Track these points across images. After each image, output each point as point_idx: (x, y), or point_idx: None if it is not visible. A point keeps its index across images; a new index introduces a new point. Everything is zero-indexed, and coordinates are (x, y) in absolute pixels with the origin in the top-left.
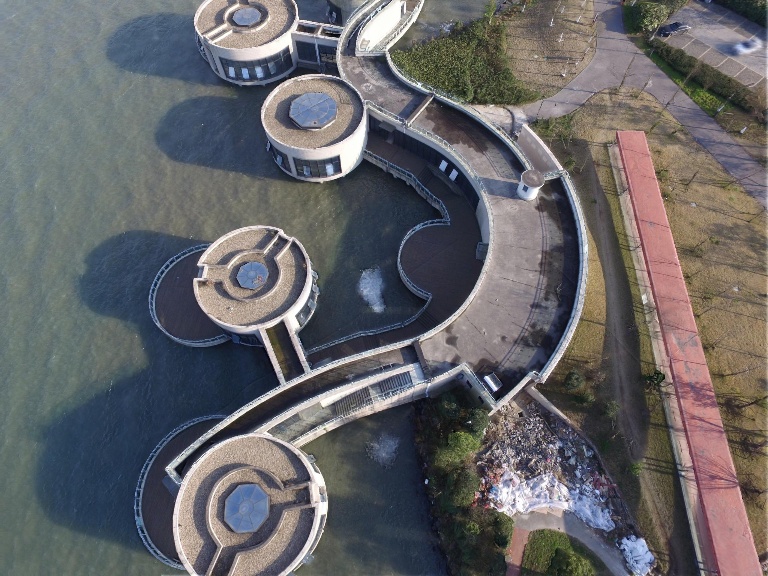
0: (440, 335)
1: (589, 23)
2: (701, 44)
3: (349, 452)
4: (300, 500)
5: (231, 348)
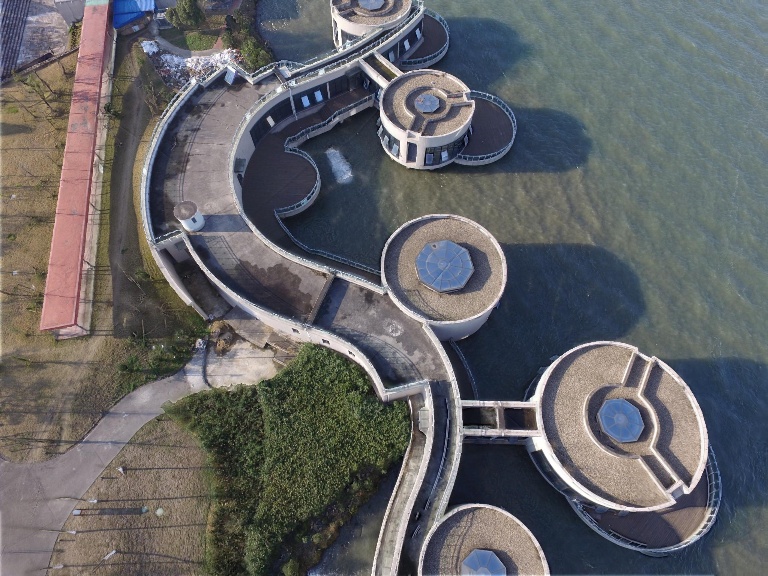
0: None
1: None
2: None
3: None
4: (343, 10)
5: None
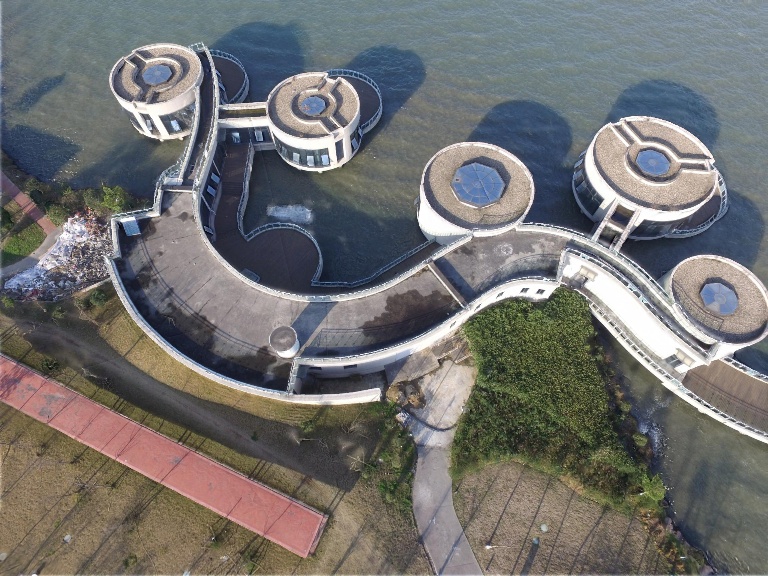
0: None
1: None
2: None
3: None
4: (143, 99)
5: None
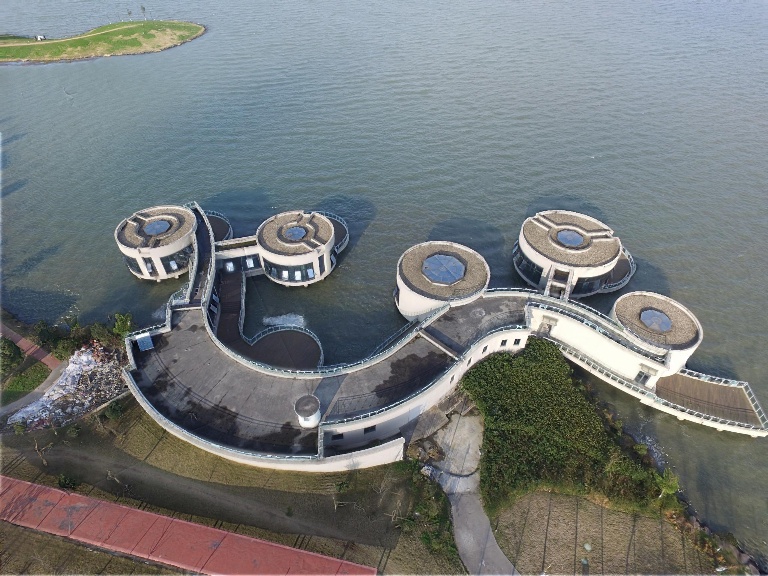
0: (202, 322)
1: None
2: None
3: None
4: (146, 246)
5: None
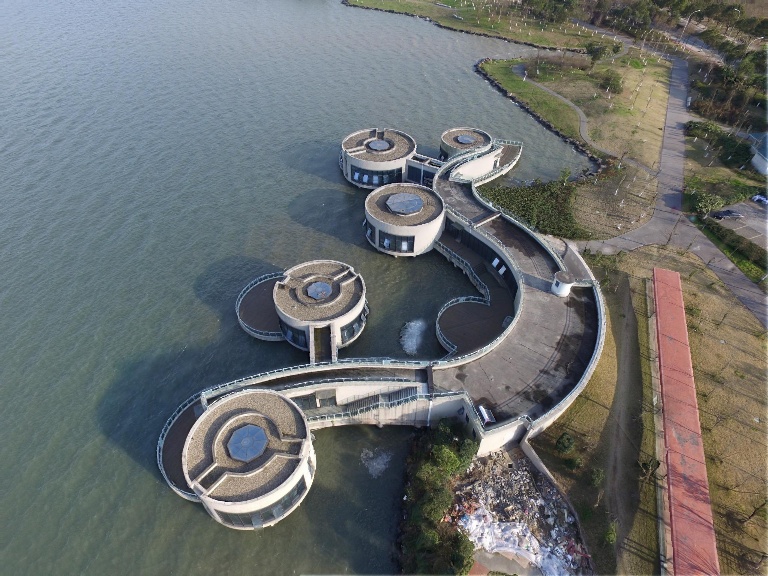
0: (452, 370)
1: (650, 199)
2: (753, 230)
3: (346, 452)
4: (291, 452)
5: (283, 347)
